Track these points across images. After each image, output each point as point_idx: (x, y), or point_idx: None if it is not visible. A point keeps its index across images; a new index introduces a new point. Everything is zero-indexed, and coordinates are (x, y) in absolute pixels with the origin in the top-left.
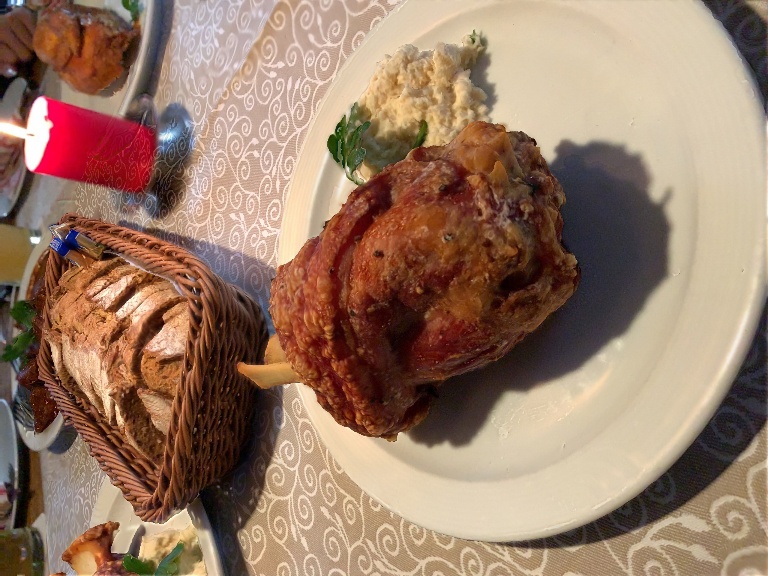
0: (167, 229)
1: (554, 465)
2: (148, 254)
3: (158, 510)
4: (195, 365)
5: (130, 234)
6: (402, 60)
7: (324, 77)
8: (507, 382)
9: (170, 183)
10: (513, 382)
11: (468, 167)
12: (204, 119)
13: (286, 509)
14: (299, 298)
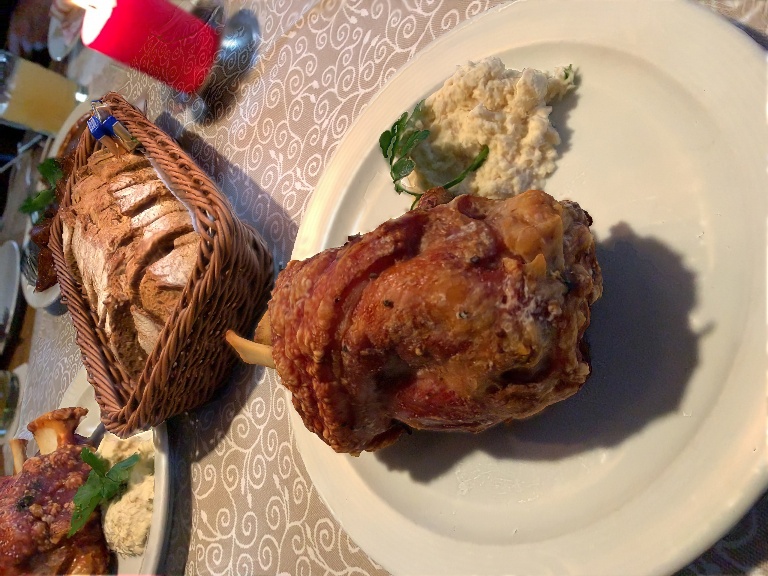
0: (206, 140)
1: (500, 547)
2: (176, 173)
3: (121, 426)
4: (191, 305)
5: (166, 141)
6: (484, 74)
7: (403, 45)
8: (483, 442)
9: (221, 94)
10: (488, 445)
11: (509, 245)
12: (272, 39)
13: (242, 461)
14: (299, 309)
